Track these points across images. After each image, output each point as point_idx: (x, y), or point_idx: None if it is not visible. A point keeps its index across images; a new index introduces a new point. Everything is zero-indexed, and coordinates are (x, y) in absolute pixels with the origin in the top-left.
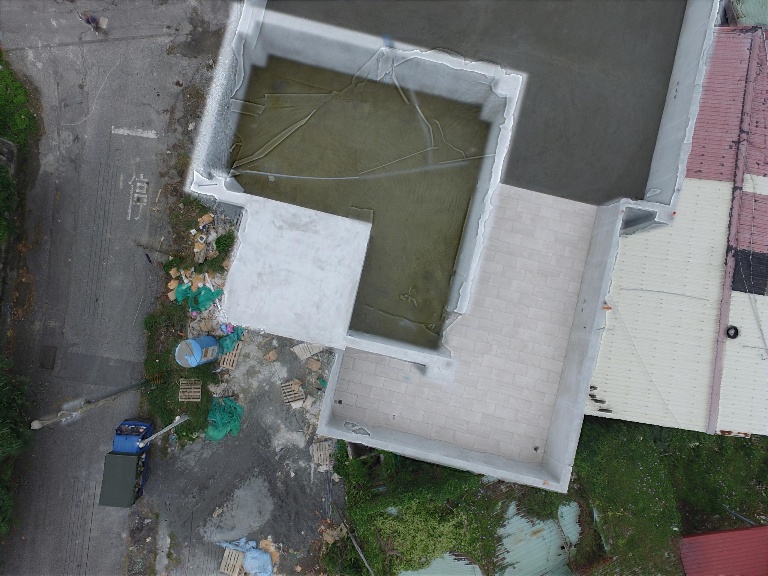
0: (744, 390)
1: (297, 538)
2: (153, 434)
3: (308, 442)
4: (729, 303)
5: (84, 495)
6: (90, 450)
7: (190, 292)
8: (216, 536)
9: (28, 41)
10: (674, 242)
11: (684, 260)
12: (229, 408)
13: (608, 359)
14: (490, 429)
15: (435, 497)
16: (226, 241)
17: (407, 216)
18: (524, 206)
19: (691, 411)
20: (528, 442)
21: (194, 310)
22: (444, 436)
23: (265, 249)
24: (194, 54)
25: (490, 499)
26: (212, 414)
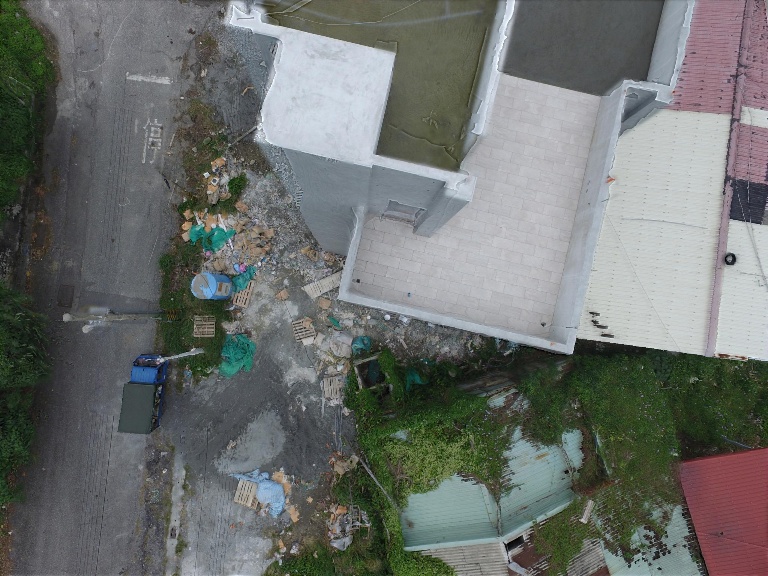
0: (742, 315)
1: (308, 470)
2: (169, 369)
3: (319, 377)
4: (727, 231)
5: (102, 428)
6: (108, 385)
7: (204, 233)
8: (230, 467)
9: None
10: (674, 173)
11: (684, 190)
12: (242, 344)
13: (610, 286)
14: (500, 305)
15: (443, 417)
16: (238, 182)
17: (428, 45)
18: (531, 96)
19: (690, 335)
20: (536, 318)
21: (207, 250)
22: (457, 310)
23: (298, 76)
24: (206, 3)
25: (496, 422)
26: (226, 350)
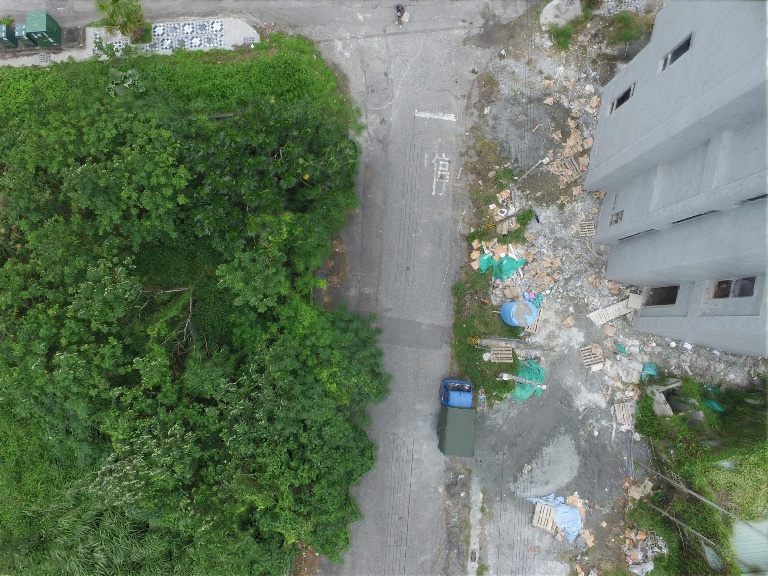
0: None
1: (601, 495)
2: None
3: (609, 403)
4: None
5: (403, 451)
6: (407, 408)
7: (493, 262)
8: (531, 491)
9: (338, 33)
10: None
11: None
12: (535, 370)
13: None
14: None
15: None
16: (529, 214)
17: None
18: None
19: None
20: None
21: (497, 278)
22: None
23: None
24: (487, 45)
25: None
26: (522, 375)
